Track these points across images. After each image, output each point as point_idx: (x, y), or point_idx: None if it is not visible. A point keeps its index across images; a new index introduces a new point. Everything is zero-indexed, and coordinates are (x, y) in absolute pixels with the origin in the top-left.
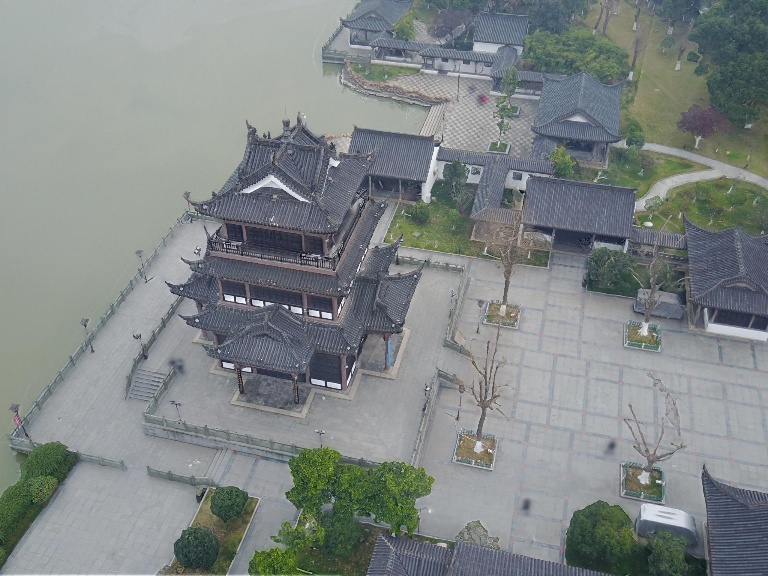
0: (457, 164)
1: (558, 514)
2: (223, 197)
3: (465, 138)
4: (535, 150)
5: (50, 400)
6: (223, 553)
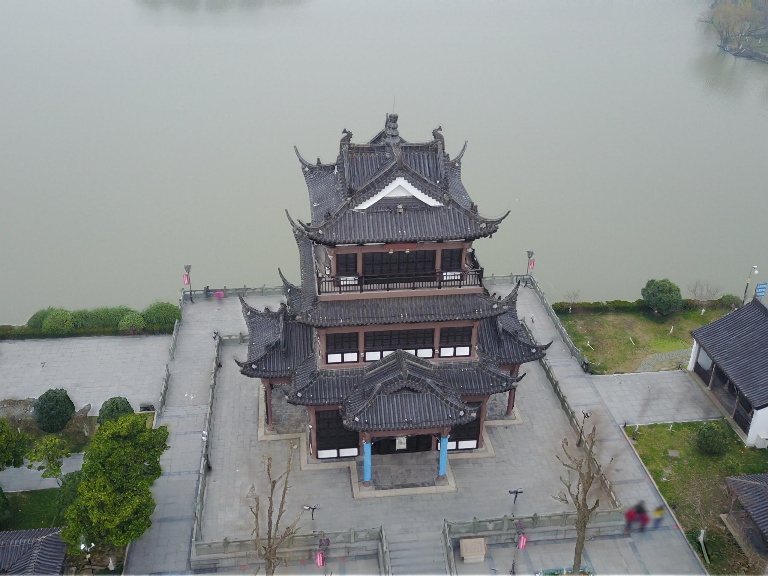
0: None
1: None
2: (325, 169)
3: None
4: None
5: None
6: (78, 444)
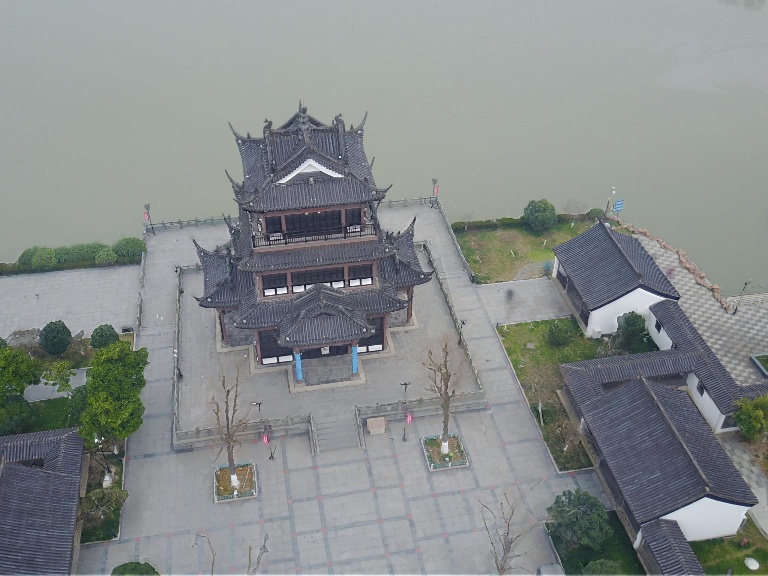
0: (631, 317)
1: (178, 570)
2: (254, 143)
3: (764, 330)
4: (764, 384)
5: (193, 229)
6: (77, 362)
